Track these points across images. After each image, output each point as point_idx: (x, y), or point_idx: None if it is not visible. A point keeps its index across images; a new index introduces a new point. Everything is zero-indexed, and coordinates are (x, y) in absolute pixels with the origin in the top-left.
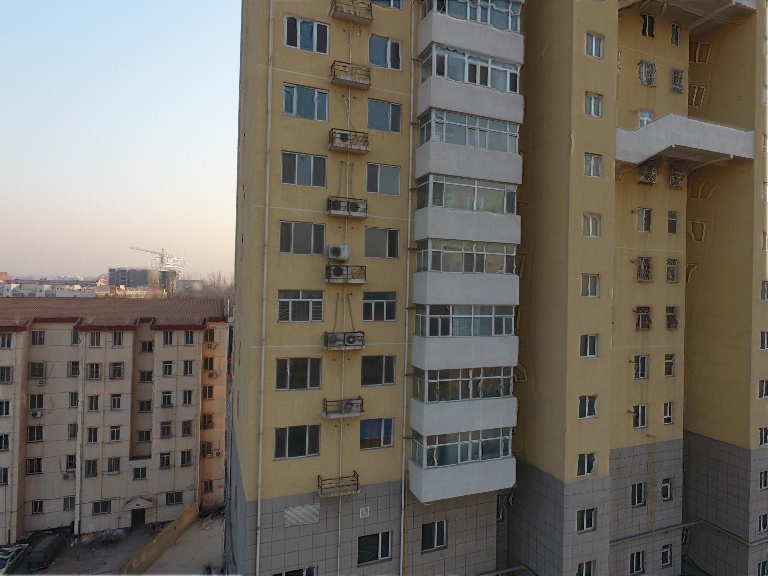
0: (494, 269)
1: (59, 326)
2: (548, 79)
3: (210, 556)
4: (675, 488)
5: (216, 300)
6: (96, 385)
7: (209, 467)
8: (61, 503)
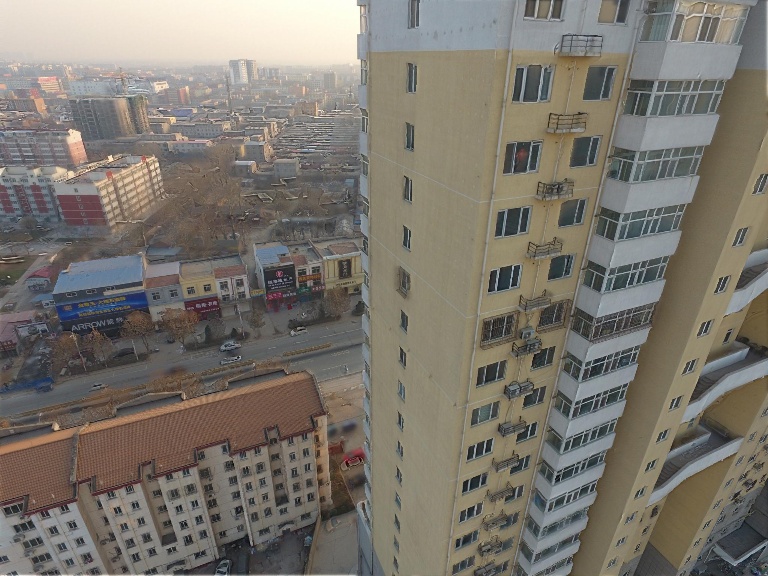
0: (560, 564)
1: (213, 447)
2: (615, 468)
3: (343, 559)
4: (631, 573)
5: (307, 380)
6: (249, 478)
7: (322, 491)
8: (236, 529)
